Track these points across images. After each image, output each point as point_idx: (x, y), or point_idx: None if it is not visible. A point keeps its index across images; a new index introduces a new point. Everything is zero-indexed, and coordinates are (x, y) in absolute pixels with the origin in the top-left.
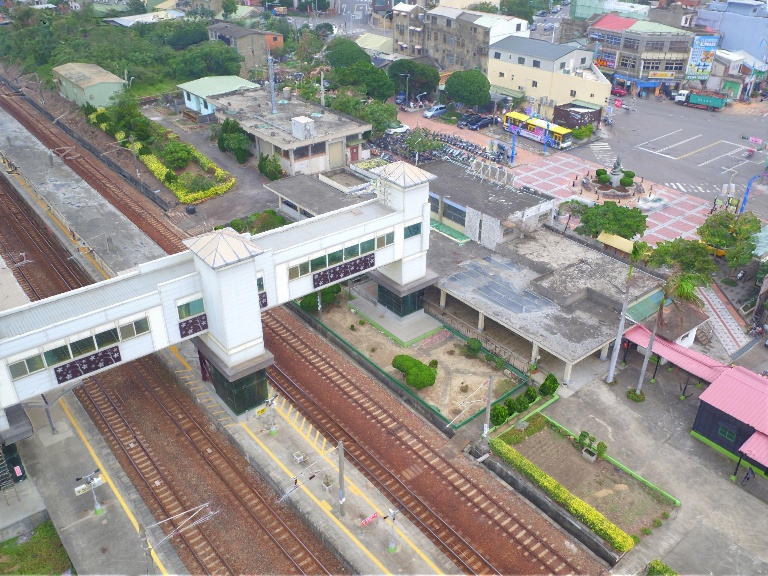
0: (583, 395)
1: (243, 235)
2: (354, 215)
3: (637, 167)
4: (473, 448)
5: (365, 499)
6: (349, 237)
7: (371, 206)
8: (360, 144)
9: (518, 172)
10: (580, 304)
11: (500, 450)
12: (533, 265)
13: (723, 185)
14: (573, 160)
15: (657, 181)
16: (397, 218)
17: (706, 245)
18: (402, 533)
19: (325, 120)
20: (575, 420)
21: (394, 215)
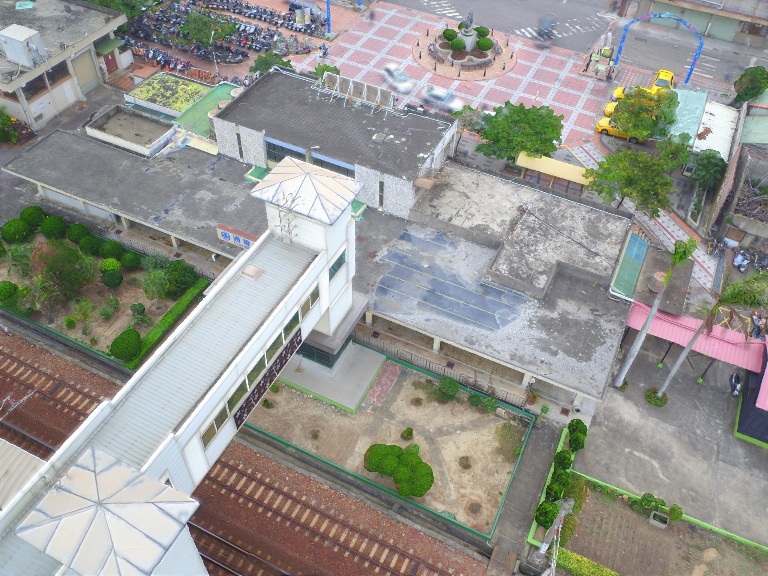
0: (603, 419)
1: (99, 412)
2: (253, 281)
3: (474, 10)
4: (523, 563)
5: None
6: (269, 333)
7: (268, 250)
8: (115, 46)
9: (343, 46)
10: (555, 287)
11: (569, 566)
12: (471, 236)
13: (601, 37)
14: (398, 12)
15: (506, 29)
16: (320, 264)
17: (661, 160)
18: None
19: (44, 14)
20: (614, 465)
21: (317, 263)
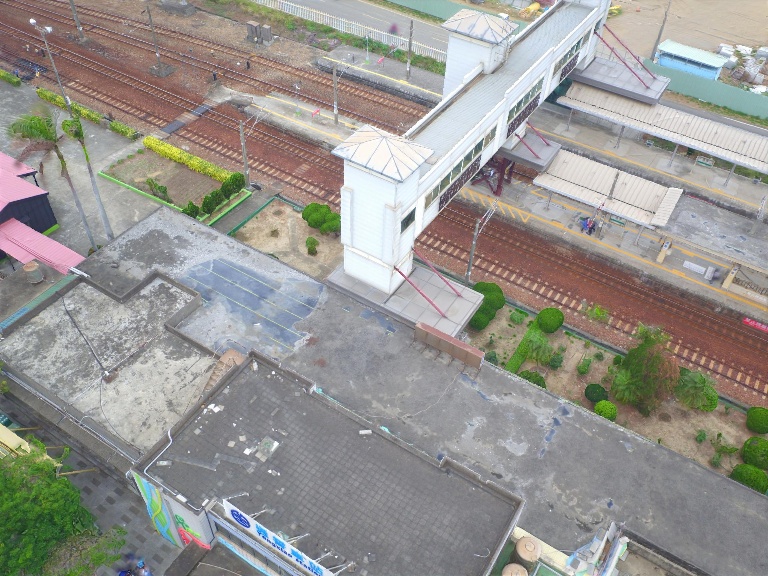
0: None
1: (509, 89)
2: None
3: None
4: None
5: (326, 132)
6: None
7: None
8: None
9: None
10: None
11: None
12: None
13: None
14: None
15: None
16: None
17: None
18: (295, 121)
19: None
20: None
21: None
